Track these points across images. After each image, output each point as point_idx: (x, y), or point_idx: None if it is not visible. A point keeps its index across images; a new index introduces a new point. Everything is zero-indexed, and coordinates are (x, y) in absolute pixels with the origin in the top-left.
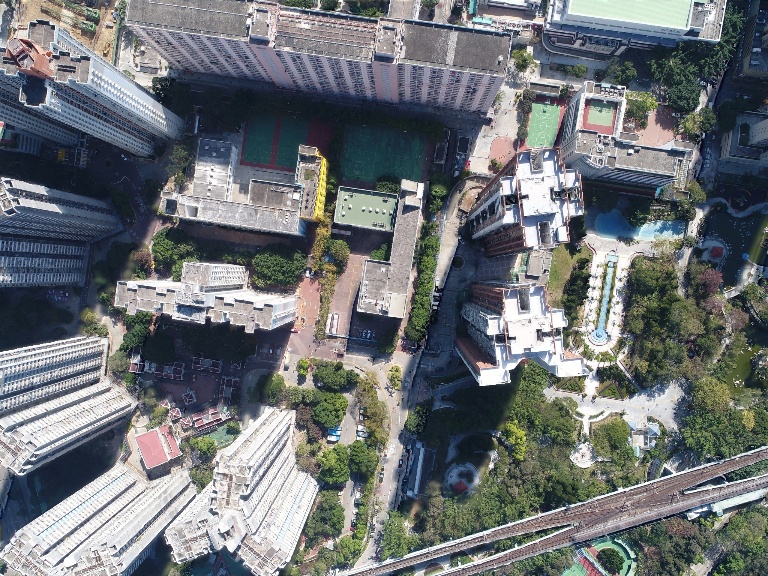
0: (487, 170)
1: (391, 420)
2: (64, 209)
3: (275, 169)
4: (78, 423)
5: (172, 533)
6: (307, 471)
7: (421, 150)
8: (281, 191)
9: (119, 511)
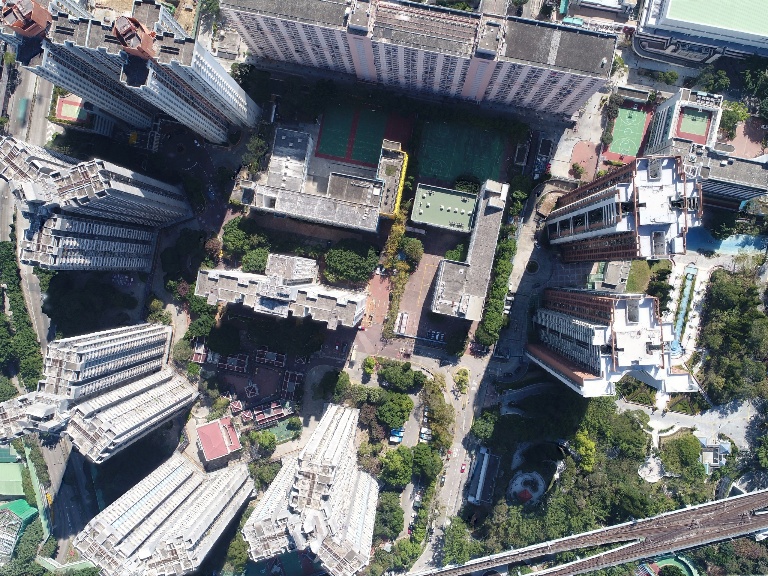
0: (567, 174)
1: (455, 424)
2: (146, 193)
3: (350, 163)
4: (149, 412)
5: (250, 530)
6: (368, 471)
7: (501, 150)
8: (361, 186)
9: (181, 503)
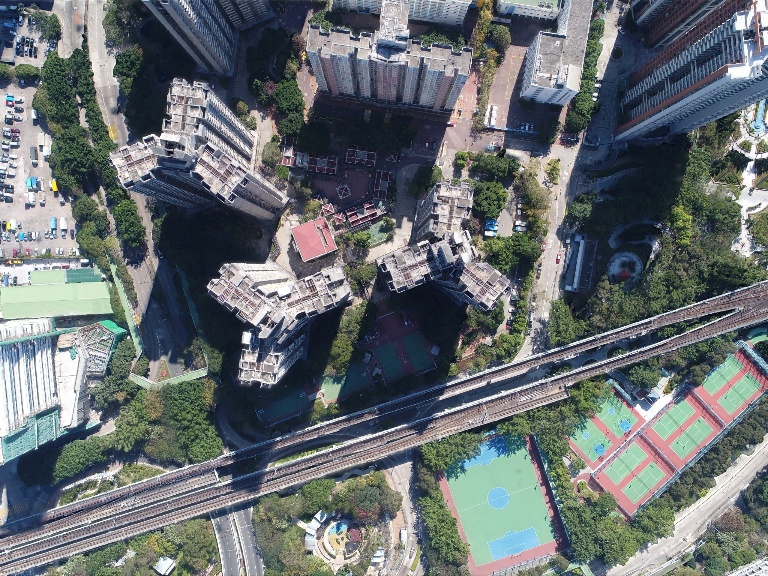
0: None
1: (549, 215)
2: None
3: None
4: None
5: (391, 260)
6: None
7: None
8: None
9: None
